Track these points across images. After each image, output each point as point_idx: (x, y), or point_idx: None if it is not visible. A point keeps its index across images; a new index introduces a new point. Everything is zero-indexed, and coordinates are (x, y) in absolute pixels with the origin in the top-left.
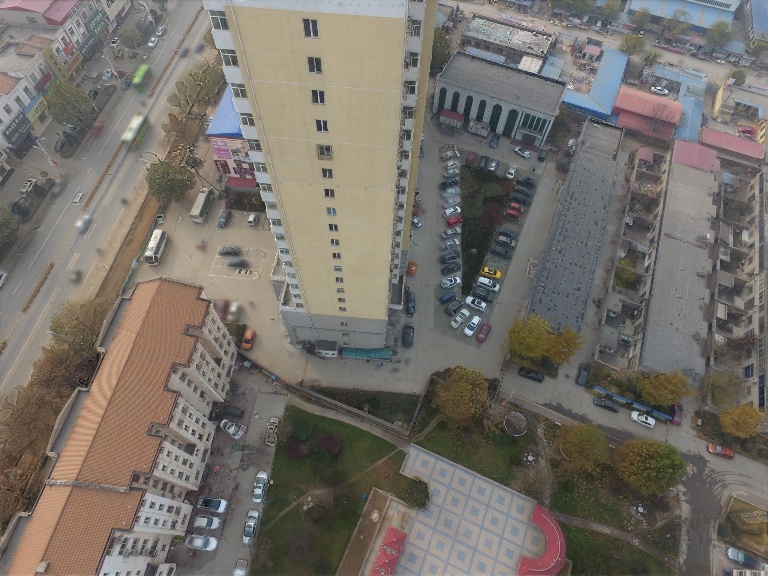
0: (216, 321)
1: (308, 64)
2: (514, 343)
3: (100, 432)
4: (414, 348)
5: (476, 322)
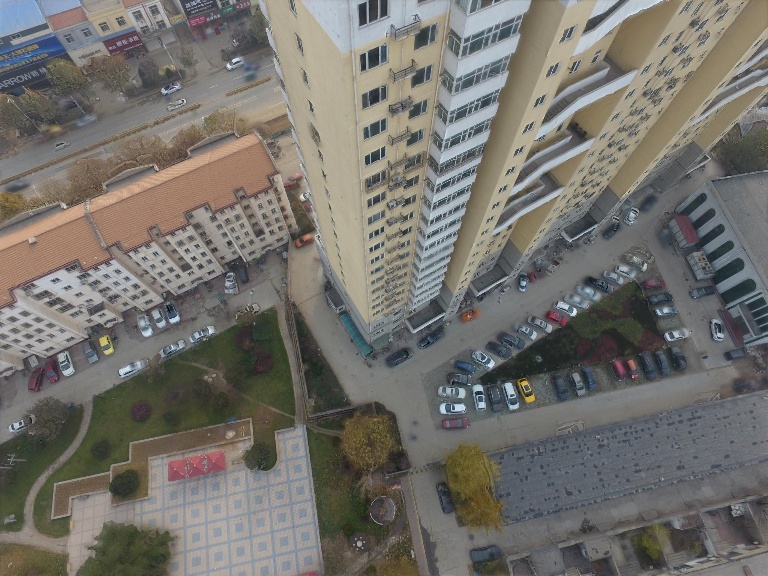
0: (274, 204)
1: (297, 39)
2: (449, 458)
3: (128, 200)
4: (392, 370)
5: (457, 409)
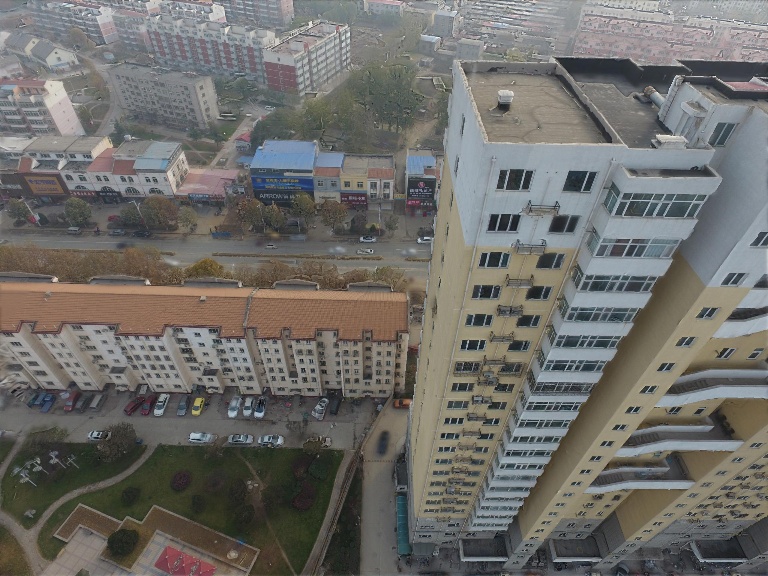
0: (391, 357)
1: None
2: None
3: (283, 301)
4: None
5: None
